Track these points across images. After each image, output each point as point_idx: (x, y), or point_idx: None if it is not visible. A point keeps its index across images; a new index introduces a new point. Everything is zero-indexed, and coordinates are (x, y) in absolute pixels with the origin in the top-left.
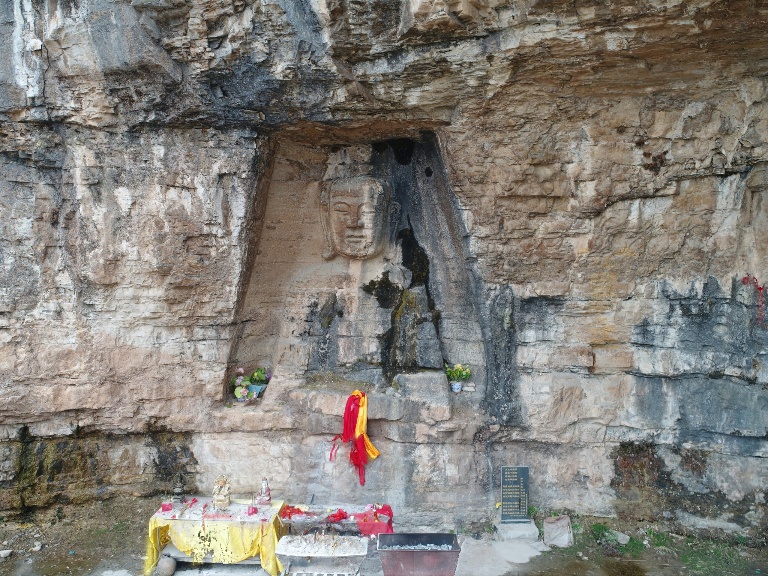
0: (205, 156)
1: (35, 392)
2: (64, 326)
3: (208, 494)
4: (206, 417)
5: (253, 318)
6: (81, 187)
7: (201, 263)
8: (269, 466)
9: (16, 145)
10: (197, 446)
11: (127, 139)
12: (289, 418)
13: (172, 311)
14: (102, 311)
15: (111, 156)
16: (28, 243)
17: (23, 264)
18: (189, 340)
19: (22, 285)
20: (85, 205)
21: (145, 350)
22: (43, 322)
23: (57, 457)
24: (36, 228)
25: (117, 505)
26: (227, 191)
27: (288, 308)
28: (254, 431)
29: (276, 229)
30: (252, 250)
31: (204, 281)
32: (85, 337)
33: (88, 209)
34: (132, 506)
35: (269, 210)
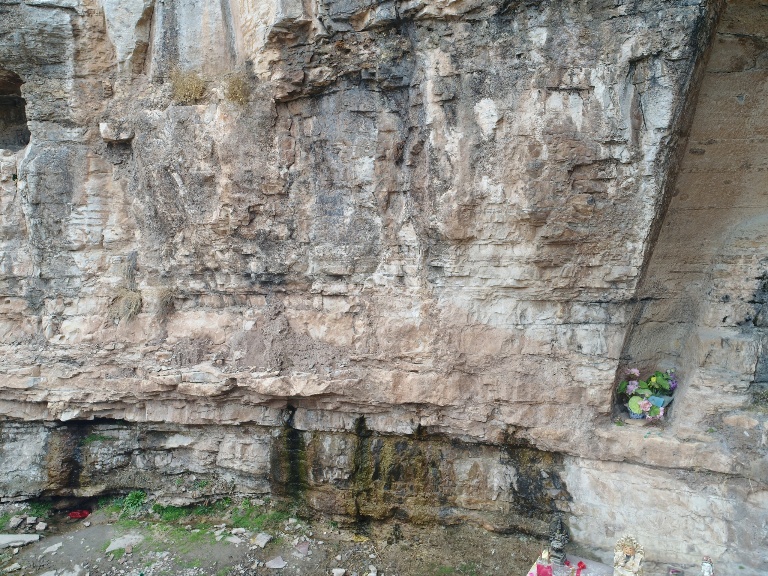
0: (610, 33)
1: (373, 376)
2: (407, 295)
3: (588, 548)
4: (586, 435)
5: (656, 295)
6: (432, 106)
7: (593, 205)
8: (688, 527)
9: (359, 62)
10: (571, 475)
11: (494, 26)
12: (725, 456)
13: (544, 278)
14: (452, 276)
15: (472, 56)
16: (369, 189)
17: (363, 216)
18: (565, 322)
19: (362, 242)
20: (436, 131)
21: (505, 332)
22: (383, 289)
23: (395, 460)
24: (378, 169)
25: (464, 536)
26: (641, 88)
27: (719, 280)
28: (661, 467)
29: (705, 154)
30: (670, 185)
31: (594, 234)
32: (431, 310)
33: (440, 136)
34: (483, 542)
35: (697, 123)
